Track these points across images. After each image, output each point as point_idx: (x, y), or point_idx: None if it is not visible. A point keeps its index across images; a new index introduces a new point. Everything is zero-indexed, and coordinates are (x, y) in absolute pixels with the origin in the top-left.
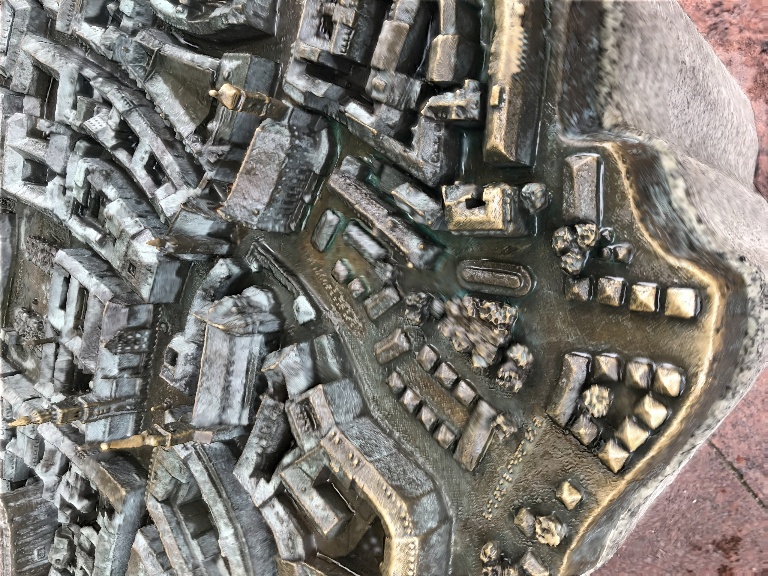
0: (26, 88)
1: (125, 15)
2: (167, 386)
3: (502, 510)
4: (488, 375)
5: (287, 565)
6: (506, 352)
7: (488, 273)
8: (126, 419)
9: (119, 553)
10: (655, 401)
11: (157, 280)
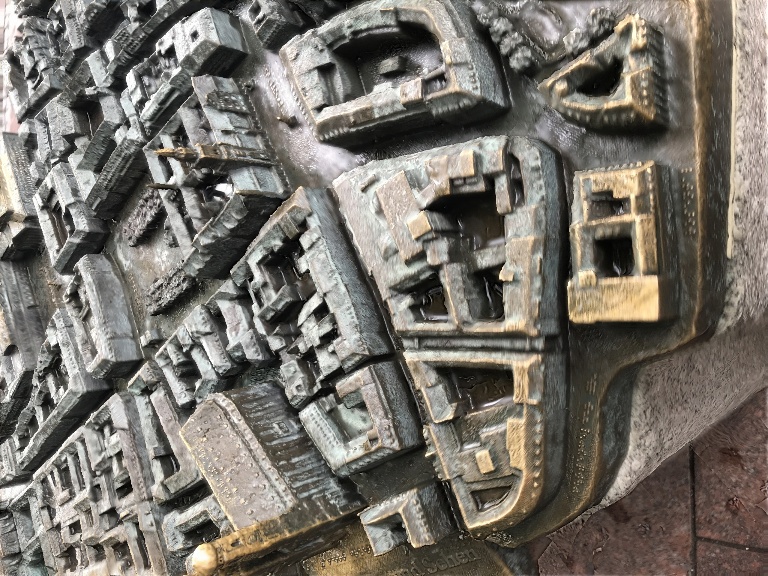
0: (72, 128)
1: None
2: (282, 112)
3: None
4: None
5: None
6: None
7: None
8: (268, 175)
9: (340, 266)
10: None
11: (217, 25)
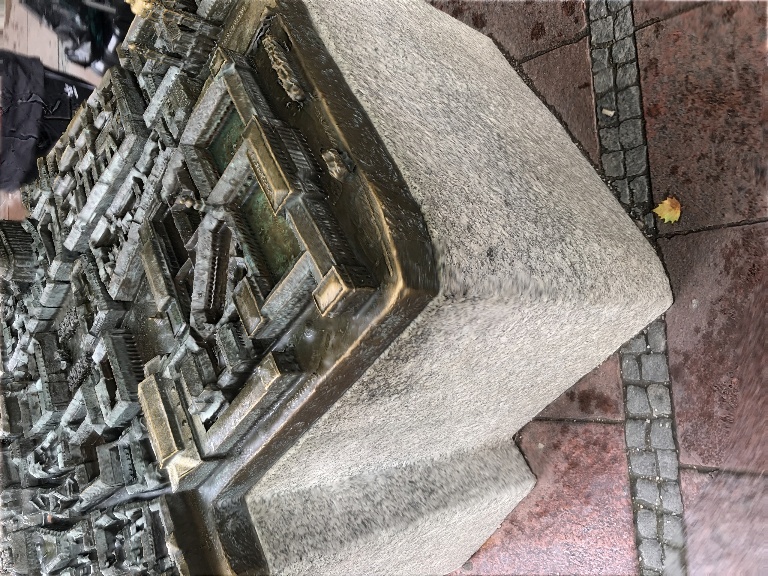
0: None
1: None
2: None
3: None
4: (9, 547)
5: None
6: None
7: (11, 575)
8: None
9: None
10: None
11: None
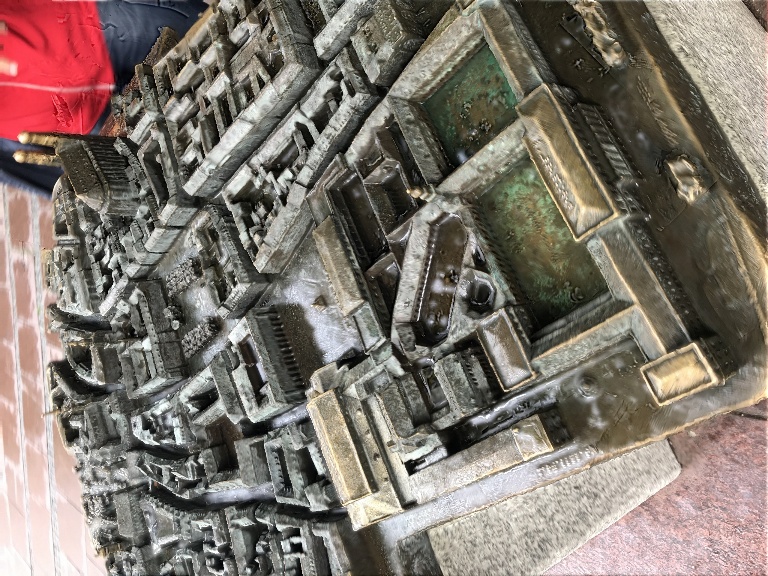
0: None
1: (205, 540)
2: None
3: (83, 459)
4: None
5: (68, 396)
6: (93, 505)
7: None
8: None
9: None
10: (86, 516)
11: None
